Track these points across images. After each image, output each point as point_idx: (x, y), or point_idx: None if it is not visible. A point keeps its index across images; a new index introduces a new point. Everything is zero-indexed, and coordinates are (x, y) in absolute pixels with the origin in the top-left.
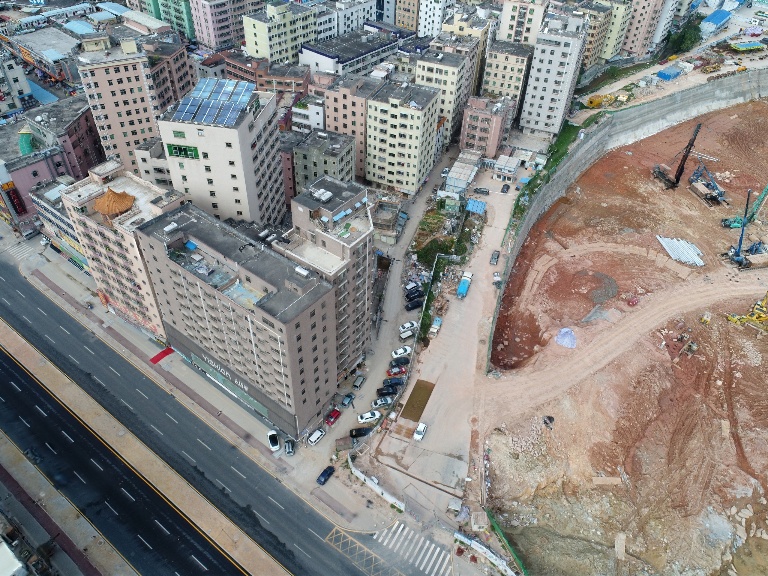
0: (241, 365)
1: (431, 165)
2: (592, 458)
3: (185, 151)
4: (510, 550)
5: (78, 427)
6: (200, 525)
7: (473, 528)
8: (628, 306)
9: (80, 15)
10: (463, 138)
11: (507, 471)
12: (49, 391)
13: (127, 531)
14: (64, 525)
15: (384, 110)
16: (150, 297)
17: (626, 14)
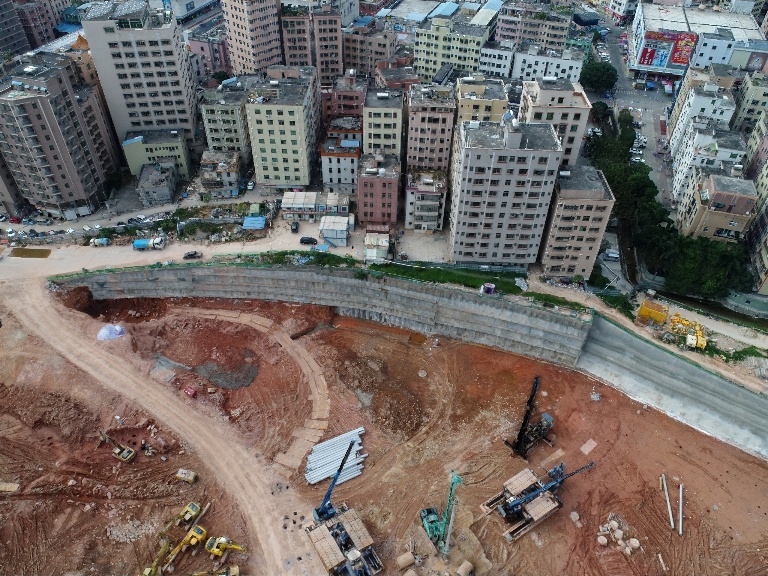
0: None
1: (303, 181)
2: None
3: None
4: None
5: None
6: None
7: None
8: None
9: None
10: None
11: None
12: None
13: None
14: None
15: None
16: None
17: None
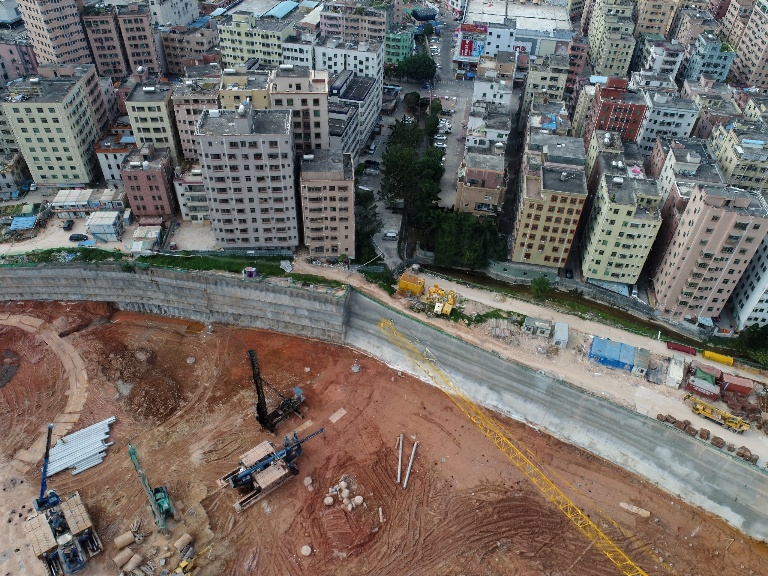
0: None
1: (83, 179)
2: None
3: None
4: None
5: None
6: None
7: None
8: None
9: None
10: None
11: None
12: None
13: None
14: None
15: None
16: None
17: (628, 222)
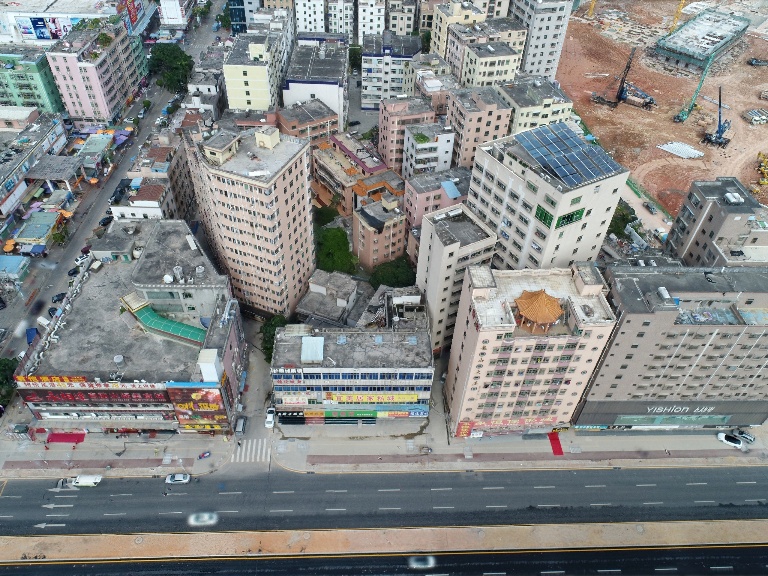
0: (721, 389)
1: None
2: None
3: (571, 217)
4: None
5: (604, 556)
6: None
7: None
8: None
9: None
10: None
11: None
12: (529, 550)
13: None
14: None
15: (537, 113)
16: (581, 385)
17: None
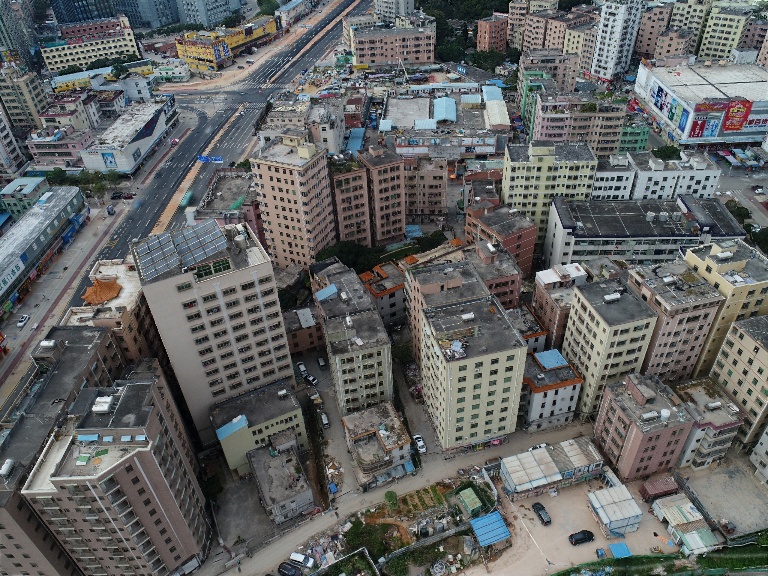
0: None
1: (509, 429)
2: None
3: None
4: None
5: None
6: None
7: None
8: None
9: (464, 92)
10: (599, 422)
11: None
12: None
13: None
14: None
15: (427, 332)
16: None
17: None
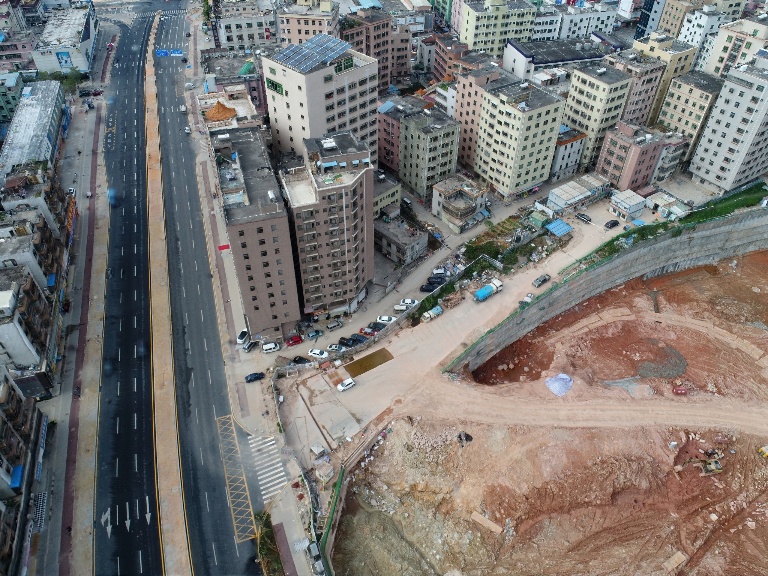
0: None
1: (545, 176)
2: (487, 495)
3: (276, 86)
4: (332, 508)
5: (145, 268)
6: (155, 363)
7: (316, 473)
8: (671, 392)
9: None
10: (600, 162)
11: (395, 456)
12: (149, 239)
13: (116, 343)
14: (91, 320)
15: (494, 104)
16: None
17: None
